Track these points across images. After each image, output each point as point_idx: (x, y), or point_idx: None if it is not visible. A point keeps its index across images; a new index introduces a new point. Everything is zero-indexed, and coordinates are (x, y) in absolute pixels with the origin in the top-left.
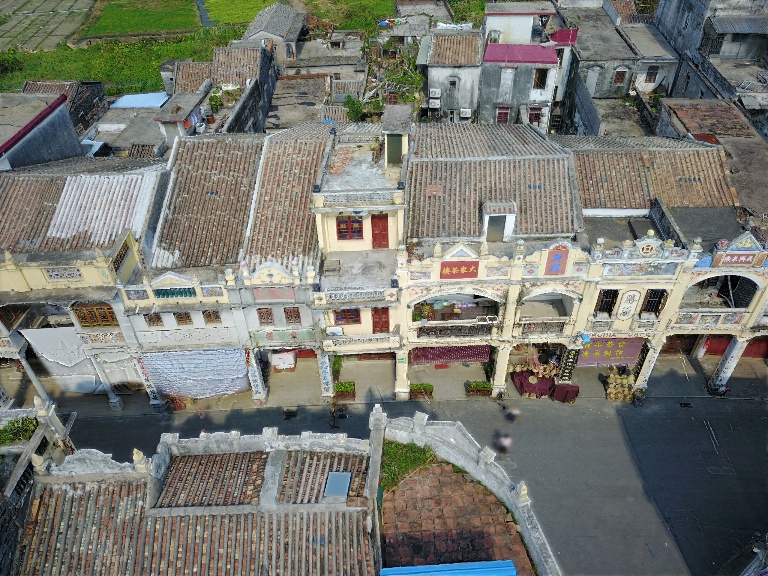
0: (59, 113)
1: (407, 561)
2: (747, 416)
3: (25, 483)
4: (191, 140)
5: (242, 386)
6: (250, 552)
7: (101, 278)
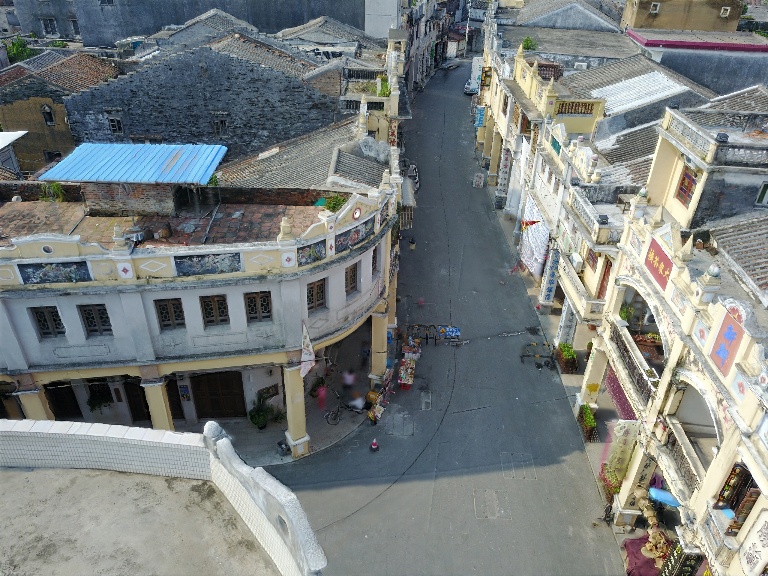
0: (761, 59)
1: (261, 211)
2: None
3: (355, 108)
4: (764, 92)
5: (535, 271)
6: (304, 186)
7: (543, 105)
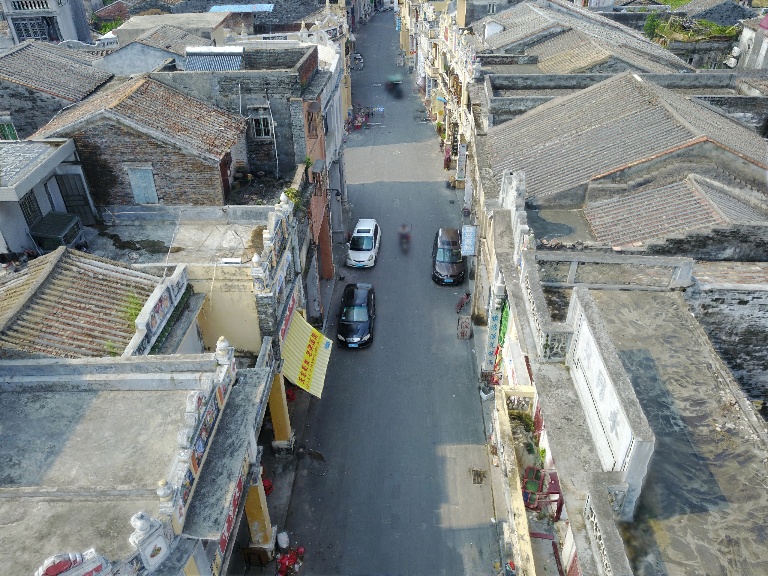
0: None
1: None
2: (446, 220)
3: (323, 3)
4: None
5: (422, 83)
6: None
7: None
